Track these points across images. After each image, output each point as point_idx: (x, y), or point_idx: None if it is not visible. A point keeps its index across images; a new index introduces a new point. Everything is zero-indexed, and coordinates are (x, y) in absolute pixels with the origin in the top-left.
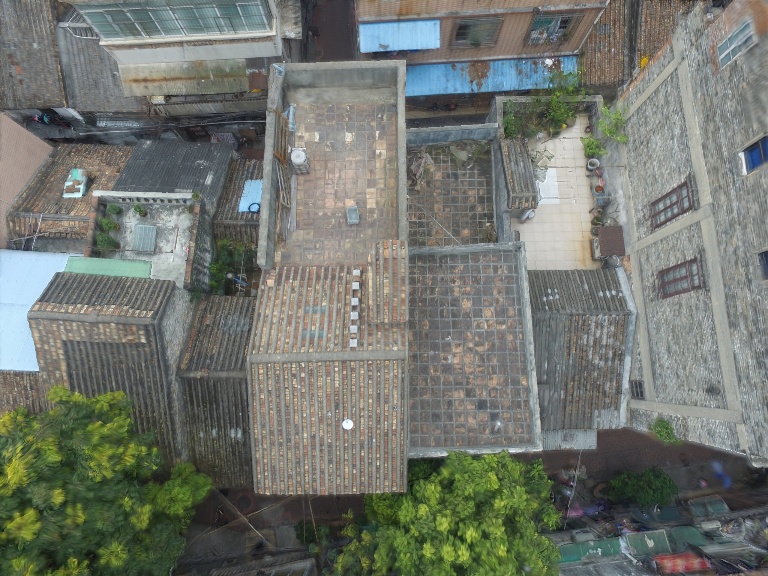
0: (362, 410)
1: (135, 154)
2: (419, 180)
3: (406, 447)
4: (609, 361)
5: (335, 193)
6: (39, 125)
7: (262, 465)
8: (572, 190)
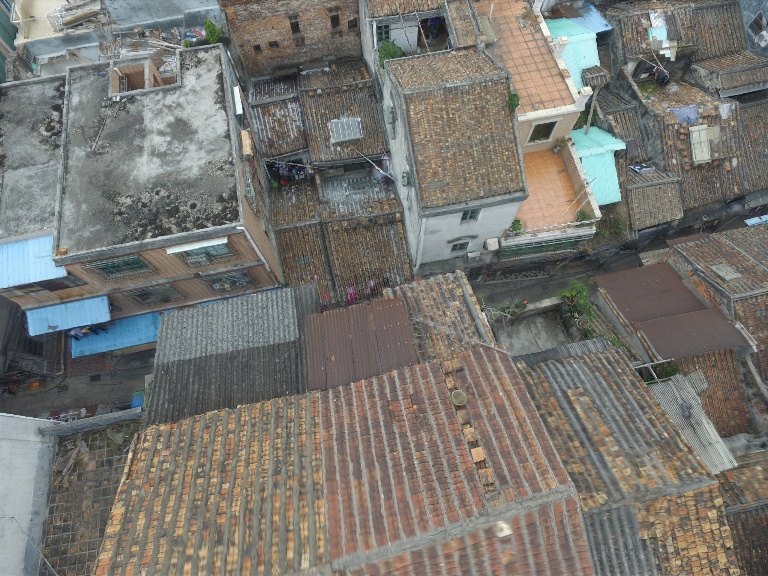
0: None
1: None
2: (67, 476)
3: None
4: None
5: None
6: None
7: None
8: None
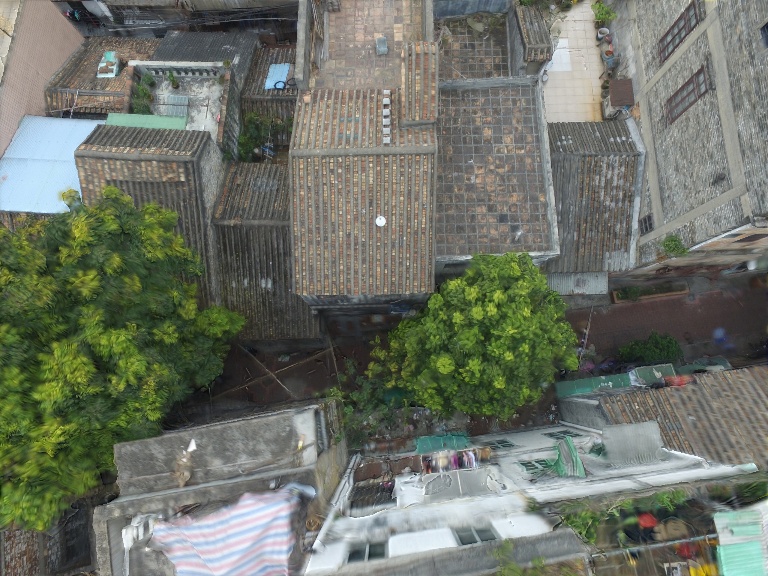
0: (394, 208)
1: (164, 41)
2: None
3: (434, 245)
4: (620, 202)
5: (364, 28)
6: (70, 21)
7: (301, 264)
8: (583, 58)
